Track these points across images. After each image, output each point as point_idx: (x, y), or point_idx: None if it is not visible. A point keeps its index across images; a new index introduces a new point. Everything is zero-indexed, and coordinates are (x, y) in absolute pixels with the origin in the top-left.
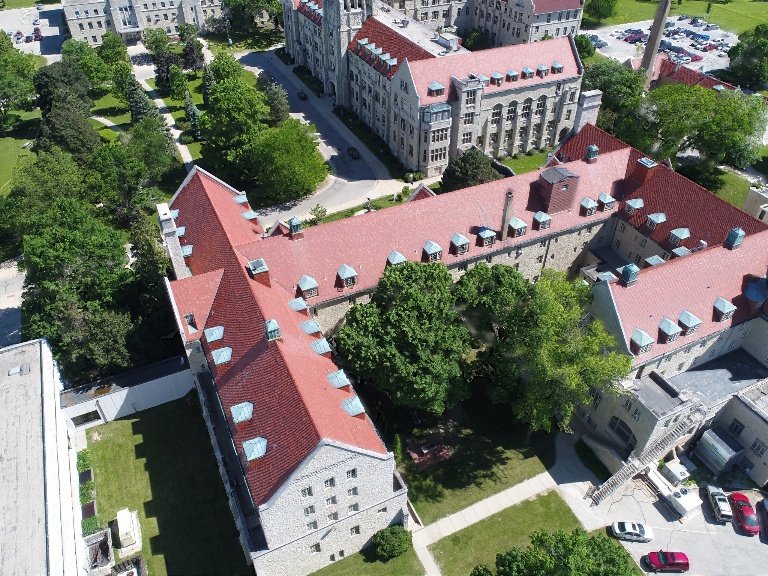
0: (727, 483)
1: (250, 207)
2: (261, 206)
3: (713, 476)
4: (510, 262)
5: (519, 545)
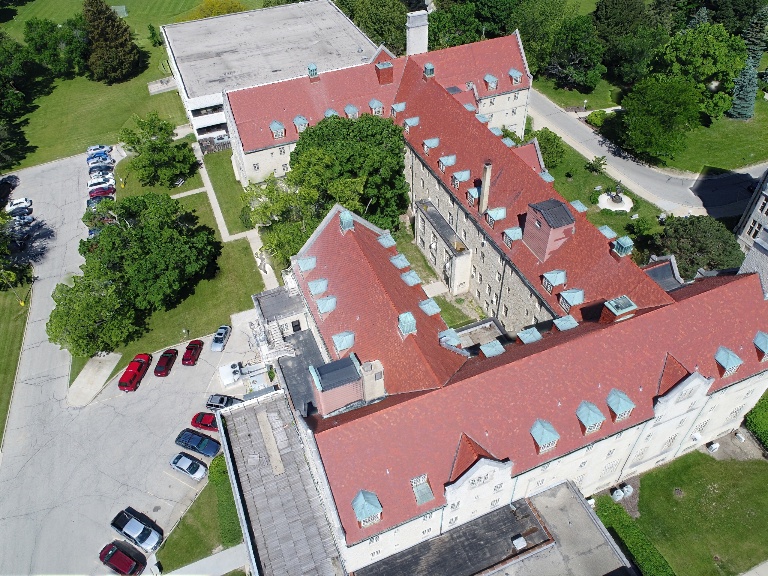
0: None
1: (522, 88)
2: (615, 140)
3: None
4: None
5: None
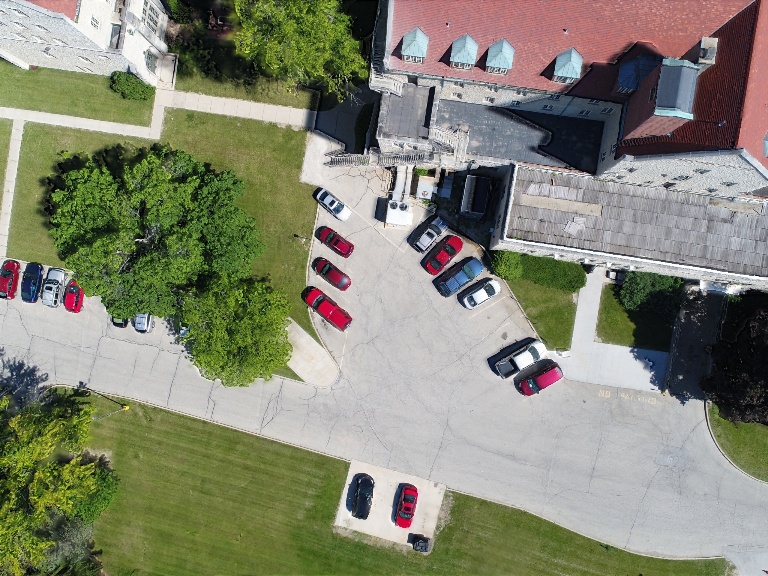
0: (464, 226)
1: None
2: None
3: (457, 213)
4: None
5: None
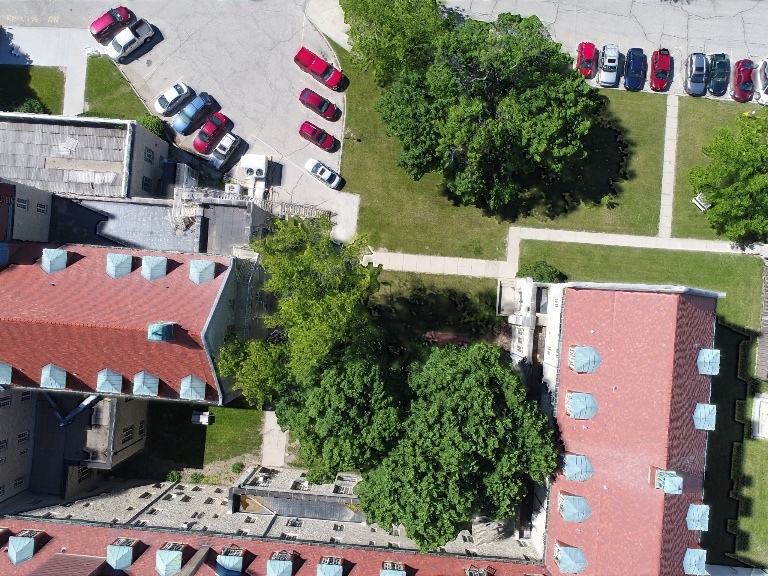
0: (194, 164)
1: None
2: None
3: (202, 175)
4: (206, 522)
5: (460, 189)
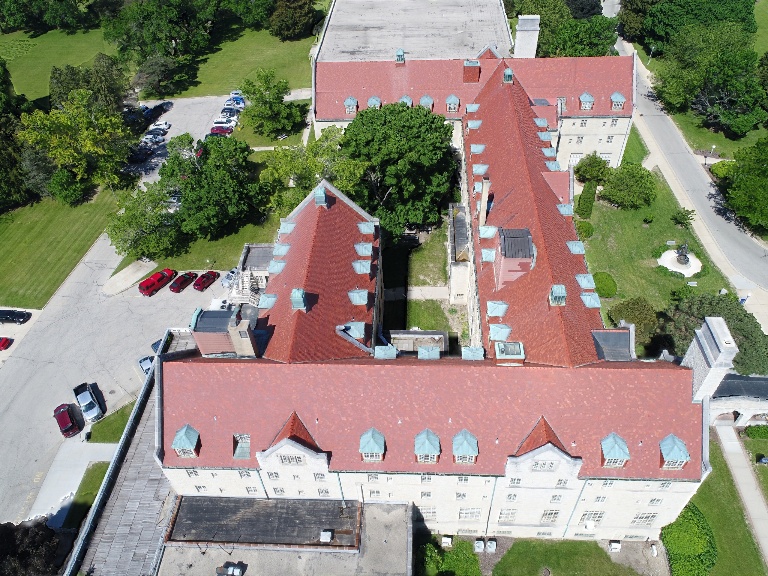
0: None
1: (622, 115)
2: None
3: None
4: None
5: None
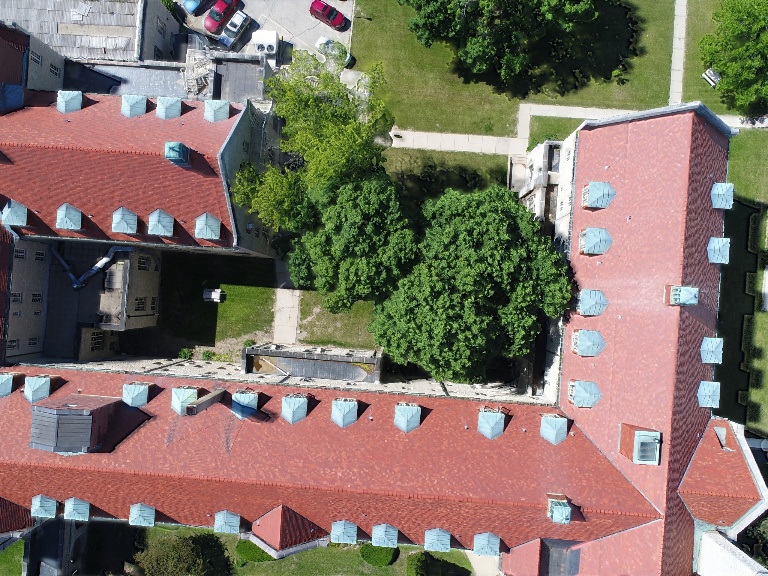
0: (205, 44)
1: None
2: None
3: None
4: None
5: (471, 53)
